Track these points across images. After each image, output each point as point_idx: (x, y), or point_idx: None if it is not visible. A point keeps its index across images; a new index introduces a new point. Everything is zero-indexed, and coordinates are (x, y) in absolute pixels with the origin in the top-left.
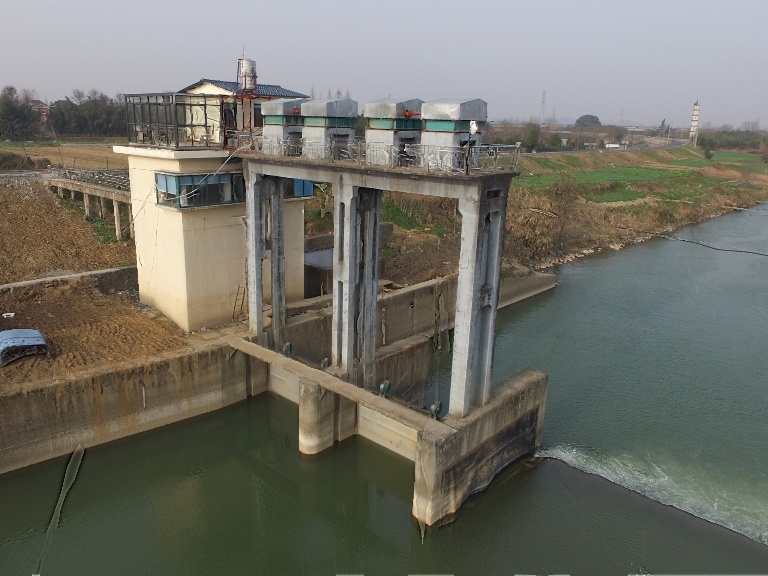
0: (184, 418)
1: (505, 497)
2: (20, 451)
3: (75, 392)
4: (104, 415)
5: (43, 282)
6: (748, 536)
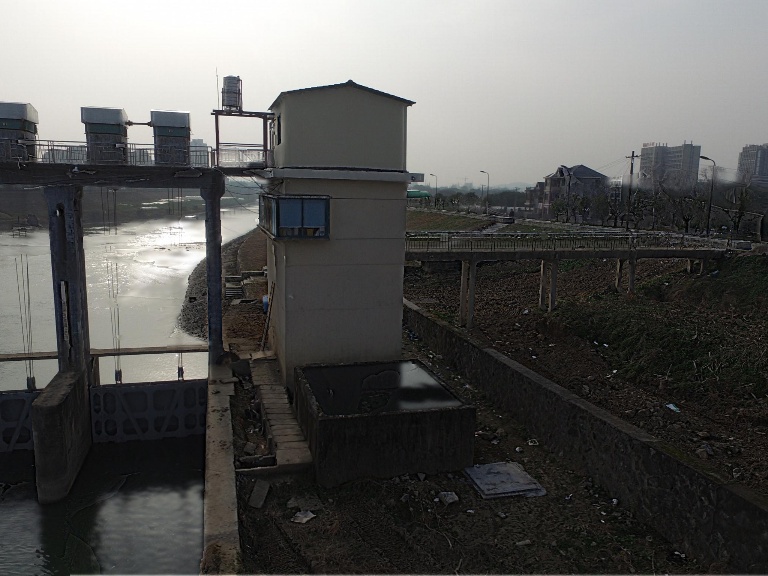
0: None
1: None
2: None
3: None
4: None
5: None
6: None
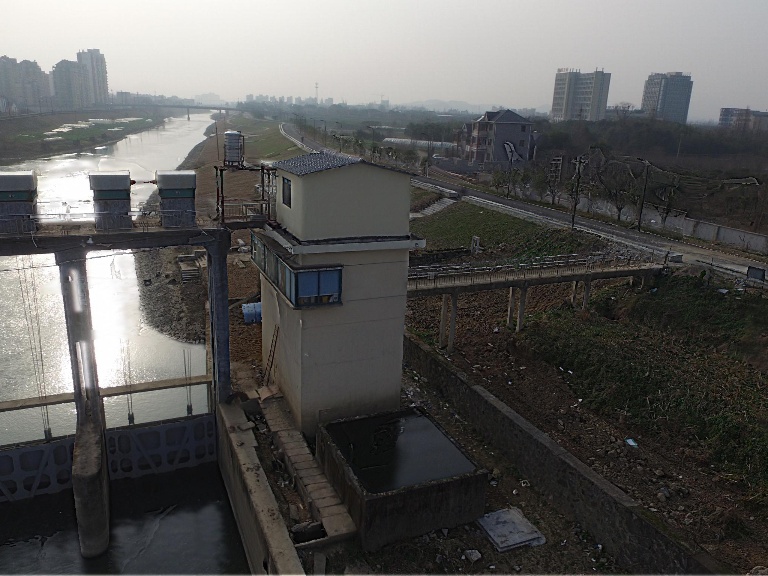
0: None
1: None
2: None
3: None
4: None
5: None
6: None
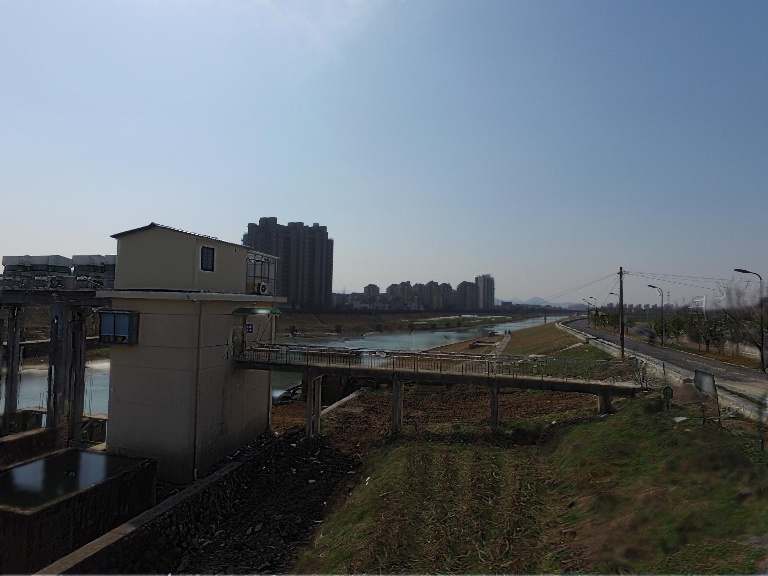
0: None
1: None
2: None
3: None
4: None
5: None
6: None
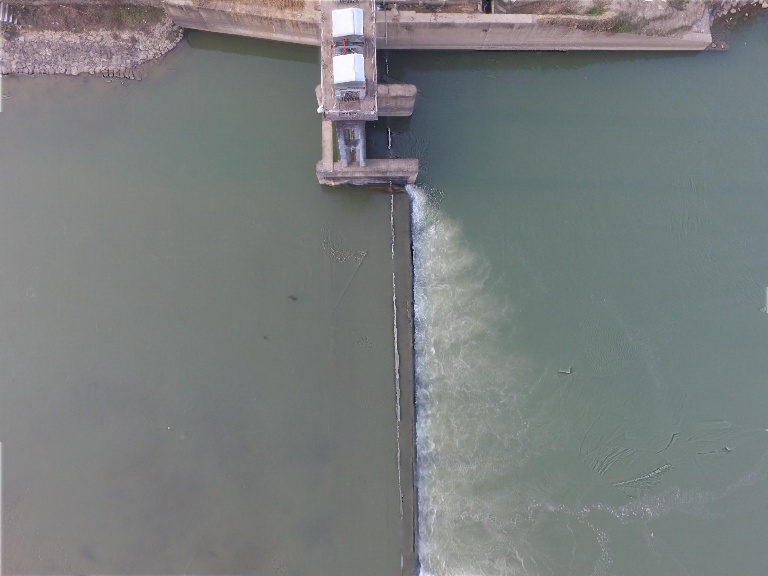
0: (297, 42)
1: (366, 192)
2: (221, 27)
3: (239, 16)
4: (255, 28)
5: None
6: (417, 276)
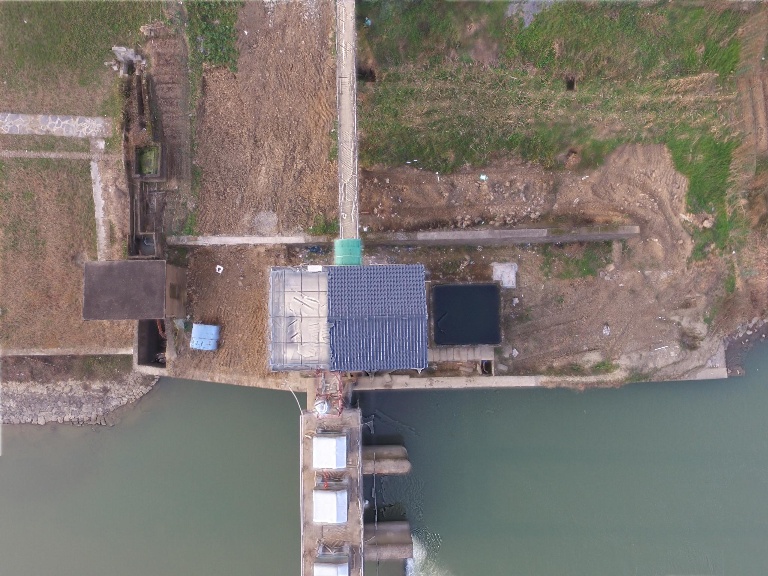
0: None
1: None
2: None
3: None
4: None
5: (247, 243)
6: None
